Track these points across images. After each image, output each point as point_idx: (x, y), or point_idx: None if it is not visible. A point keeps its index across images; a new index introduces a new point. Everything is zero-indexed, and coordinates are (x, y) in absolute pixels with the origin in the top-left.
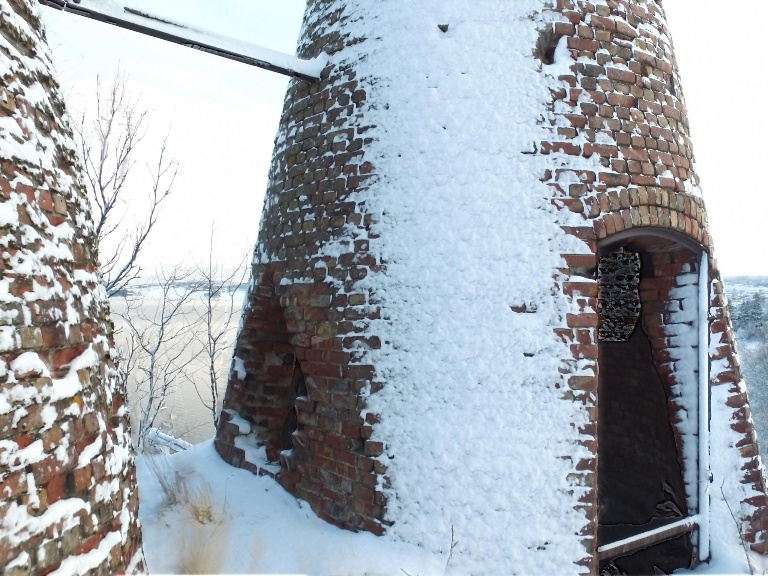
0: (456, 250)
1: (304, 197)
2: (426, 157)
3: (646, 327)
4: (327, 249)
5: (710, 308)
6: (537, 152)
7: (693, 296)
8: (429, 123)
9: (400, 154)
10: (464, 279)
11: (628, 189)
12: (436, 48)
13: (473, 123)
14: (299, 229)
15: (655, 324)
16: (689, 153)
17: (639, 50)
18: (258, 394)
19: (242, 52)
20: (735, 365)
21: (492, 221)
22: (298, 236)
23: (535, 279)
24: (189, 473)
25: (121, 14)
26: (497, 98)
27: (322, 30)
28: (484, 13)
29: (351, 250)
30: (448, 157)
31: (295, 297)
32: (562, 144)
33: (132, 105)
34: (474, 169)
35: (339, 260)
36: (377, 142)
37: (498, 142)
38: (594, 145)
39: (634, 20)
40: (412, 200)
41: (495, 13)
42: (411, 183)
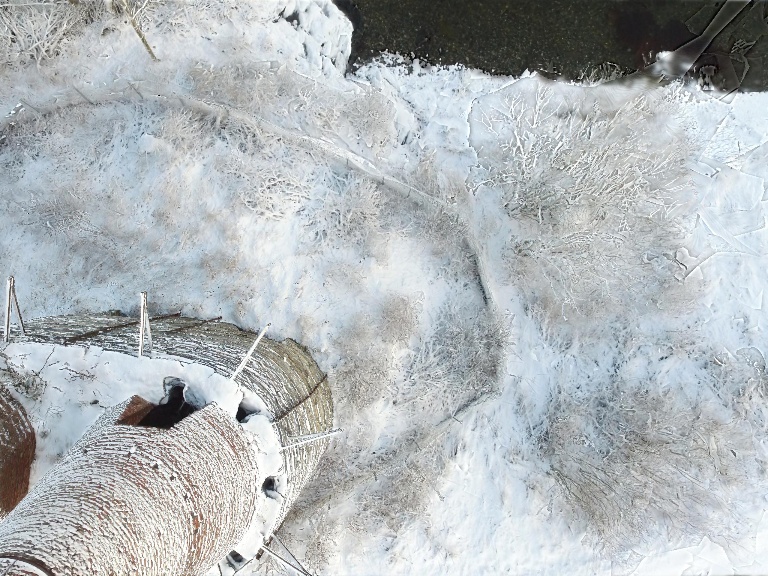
0: None
1: None
2: None
3: None
4: None
5: None
6: None
7: None
8: None
9: None
10: None
11: None
12: None
13: None
14: None
15: None
16: None
17: None
18: None
19: None
20: None
21: None
22: None
23: None
24: (70, 446)
25: None
26: None
27: None
28: None
29: None
30: None
31: None
32: None
33: None
34: None
35: None
36: None
37: None
38: None
39: None
40: None
41: None
42: None
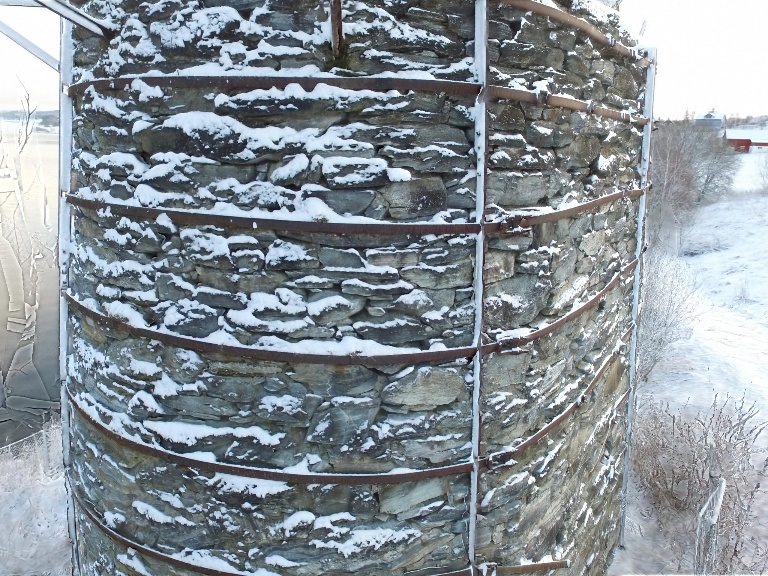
0: None
1: None
2: None
3: None
4: None
5: None
6: None
7: None
8: None
9: None
10: None
11: None
12: None
13: None
14: None
15: None
16: None
17: None
18: None
19: None
20: None
21: None
22: None
23: None
24: None
25: None
26: None
27: None
28: None
29: None
30: None
31: None
32: None
33: None
34: None
35: None
36: None
37: None
38: None
39: None
40: None
41: None
42: None
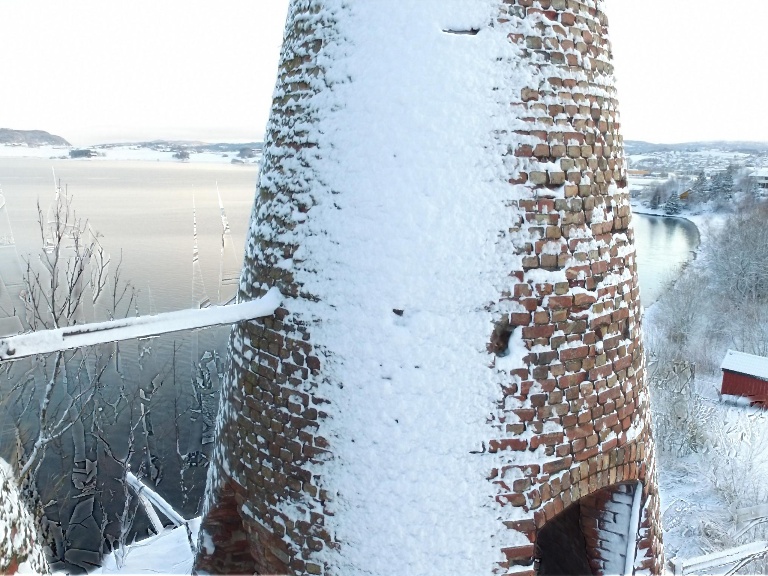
0: (405, 544)
1: (262, 439)
2: (378, 449)
3: (582, 526)
4: (285, 508)
5: (640, 529)
6: (485, 451)
7: (626, 516)
8: (382, 416)
9: (354, 439)
10: (412, 573)
11: (570, 470)
12: (390, 338)
13: (425, 422)
14: (258, 469)
15: (591, 526)
16: (636, 391)
17: (595, 317)
18: (227, 562)
19: (191, 325)
20: (656, 573)
21: (439, 519)
22: (257, 476)
23: (476, 575)
24: None
25: (60, 345)
26: (449, 398)
27: (275, 259)
28: (440, 304)
29: (307, 520)
30: (400, 453)
31: (256, 531)
32: (510, 441)
33: (78, 225)
34: (424, 468)
35: (296, 524)
36: (331, 420)
37: (448, 443)
38: (541, 437)
39: (593, 282)
40: (365, 489)
41: (451, 305)
42: (364, 472)
